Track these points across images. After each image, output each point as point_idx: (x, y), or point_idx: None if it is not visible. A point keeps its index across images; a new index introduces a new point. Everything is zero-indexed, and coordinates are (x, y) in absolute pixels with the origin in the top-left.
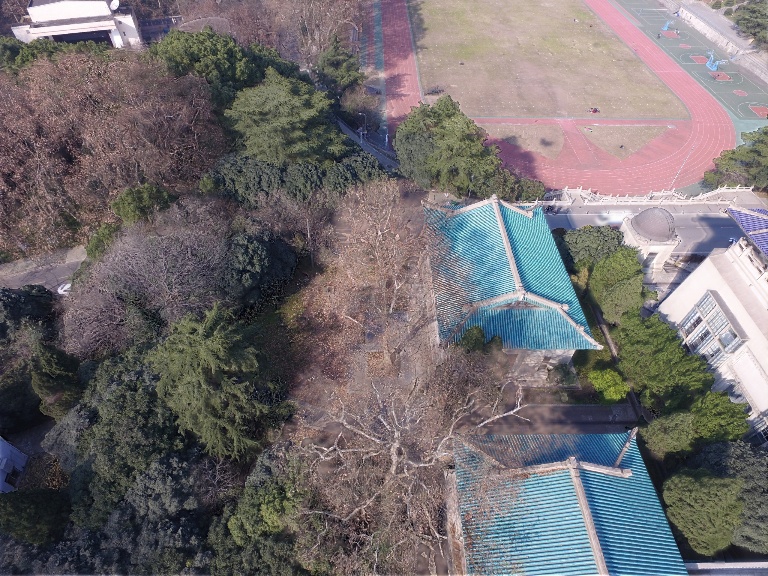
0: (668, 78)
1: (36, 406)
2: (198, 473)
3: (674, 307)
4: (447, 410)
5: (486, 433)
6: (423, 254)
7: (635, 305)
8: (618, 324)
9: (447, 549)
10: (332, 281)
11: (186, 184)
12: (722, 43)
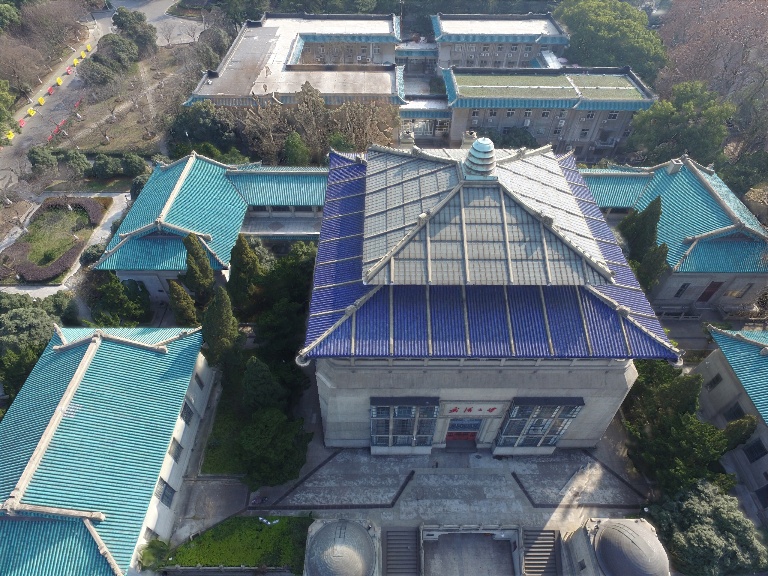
0: None
1: None
2: None
3: None
4: None
5: None
6: None
7: None
8: None
9: None
10: None
11: None
12: None
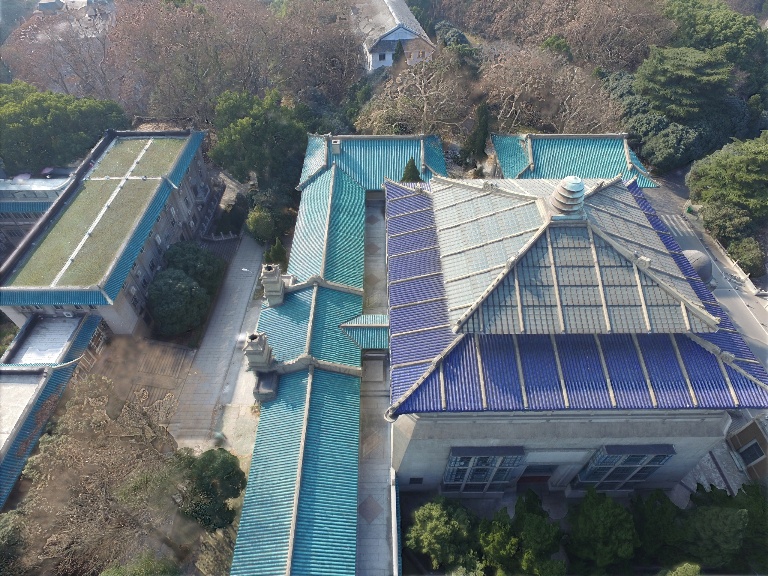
0: None
1: None
2: None
3: None
4: None
5: None
6: None
7: None
8: None
9: None
10: None
11: (593, 68)
12: None
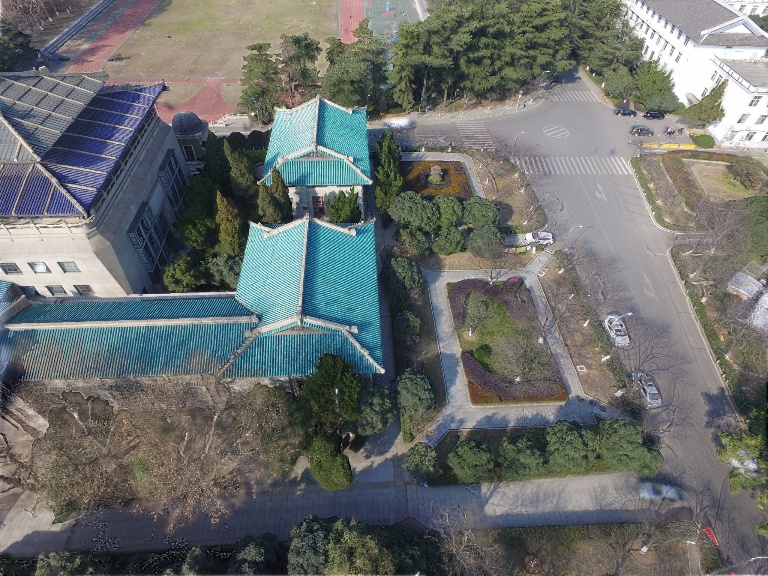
0: None
1: None
2: None
3: None
4: None
5: None
6: None
7: None
8: None
9: None
10: None
11: None
12: None
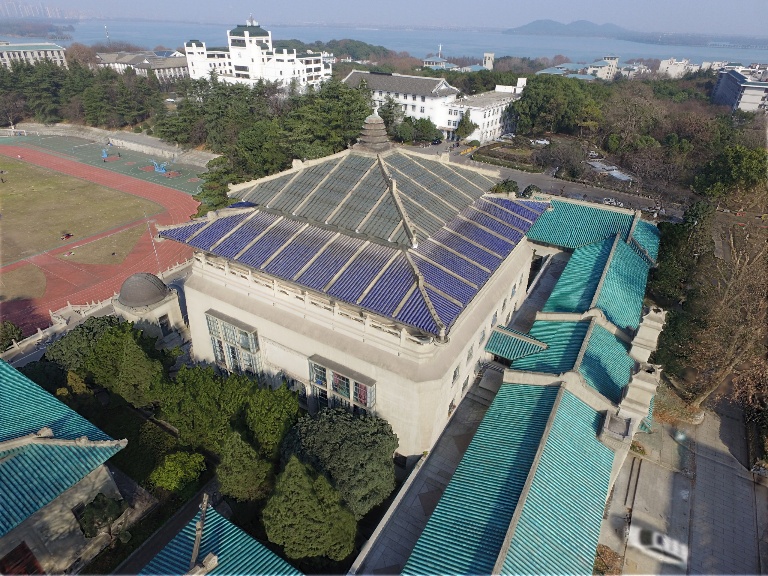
0: (128, 188)
1: None
2: None
3: (202, 349)
4: None
5: None
6: None
7: (153, 372)
8: (156, 403)
9: None
10: None
11: None
12: (159, 153)
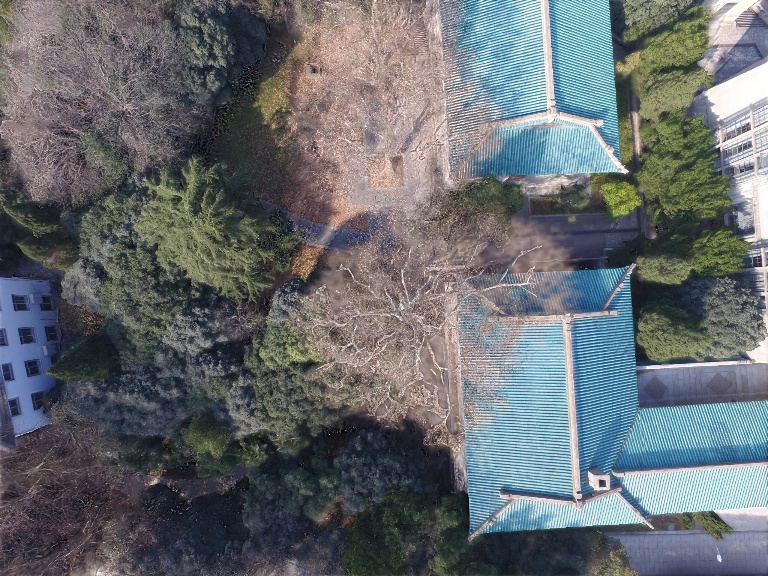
0: None
1: (30, 234)
2: (221, 317)
3: (726, 98)
4: (452, 236)
5: (487, 246)
6: (440, 98)
7: (681, 105)
8: (653, 122)
9: (443, 341)
10: (316, 54)
11: None
12: None
